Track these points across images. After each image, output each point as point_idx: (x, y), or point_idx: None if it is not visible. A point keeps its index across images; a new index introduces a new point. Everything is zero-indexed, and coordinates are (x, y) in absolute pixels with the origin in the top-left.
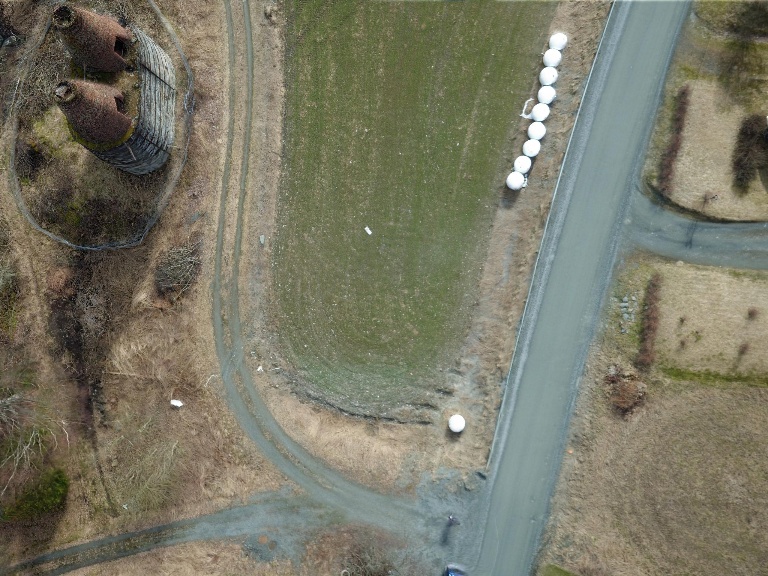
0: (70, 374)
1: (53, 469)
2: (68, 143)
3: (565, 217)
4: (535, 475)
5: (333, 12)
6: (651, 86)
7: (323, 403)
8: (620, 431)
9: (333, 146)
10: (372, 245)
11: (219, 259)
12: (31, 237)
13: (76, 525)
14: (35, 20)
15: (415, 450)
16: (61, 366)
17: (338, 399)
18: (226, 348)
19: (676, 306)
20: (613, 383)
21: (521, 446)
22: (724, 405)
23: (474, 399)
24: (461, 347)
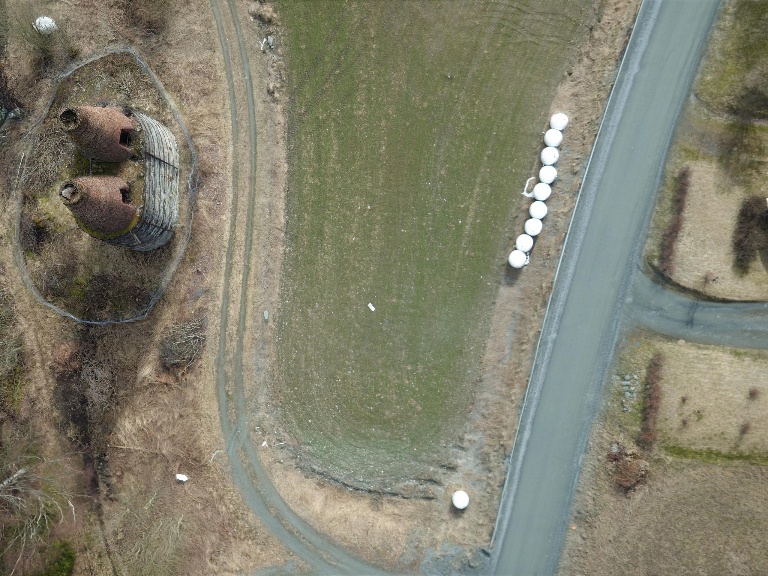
0: (76, 447)
1: (59, 542)
2: (73, 219)
3: (567, 296)
4: (539, 552)
5: (335, 90)
6: (652, 166)
7: (327, 478)
8: (623, 508)
9: (336, 223)
10: (375, 321)
11: (223, 335)
12: (36, 310)
13: None
14: (39, 93)
15: (419, 526)
16: (67, 439)
17: (342, 474)
18: (231, 424)
19: (678, 385)
20: (616, 461)
21: (525, 523)
22: (726, 483)
23: (478, 475)
24: (464, 423)
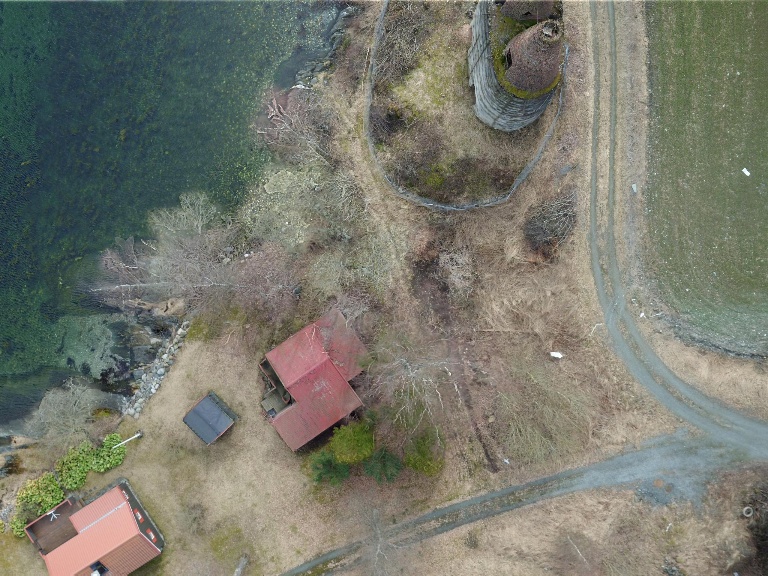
0: (438, 335)
1: None
2: (433, 105)
3: None
4: None
5: None
6: None
7: (708, 345)
8: None
9: (704, 91)
10: (751, 186)
11: (594, 210)
12: (387, 203)
13: (455, 483)
14: None
15: None
16: (428, 327)
17: (724, 340)
18: (608, 297)
19: None
20: None
21: None
22: None
23: None
24: None
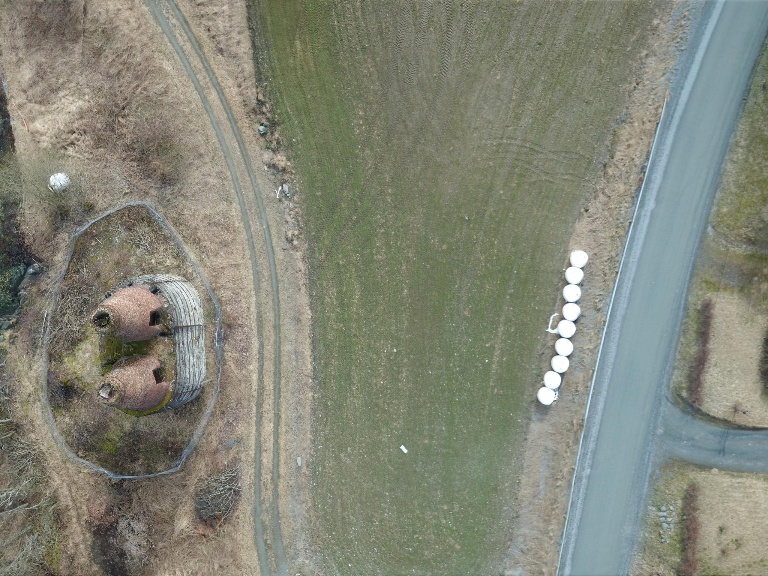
0: None
1: None
2: (100, 378)
3: (598, 432)
4: None
5: (354, 235)
6: (674, 299)
7: None
8: None
9: (363, 367)
10: (409, 463)
11: (258, 484)
12: (68, 466)
13: None
14: (57, 248)
15: None
16: None
17: None
18: (271, 572)
19: (714, 515)
20: None
21: None
22: None
23: None
24: (504, 559)
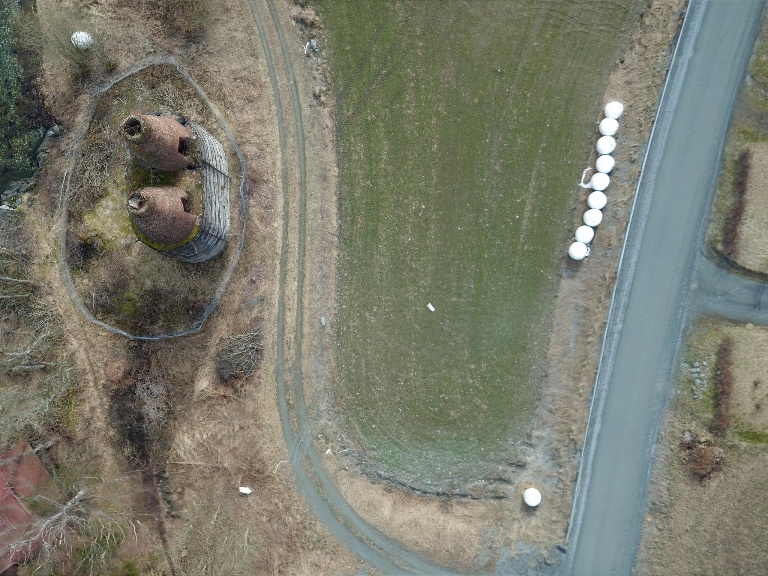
0: (134, 465)
1: (122, 563)
2: (121, 234)
3: (631, 286)
4: (615, 546)
5: (383, 90)
6: (711, 150)
7: (394, 483)
8: (698, 497)
9: (390, 224)
10: (436, 322)
11: (281, 343)
12: (86, 329)
13: None
14: (78, 110)
15: (491, 526)
16: (124, 458)
17: (409, 478)
18: (293, 433)
19: (749, 370)
20: (689, 449)
21: (599, 517)
22: None
23: (548, 471)
24: (531, 420)
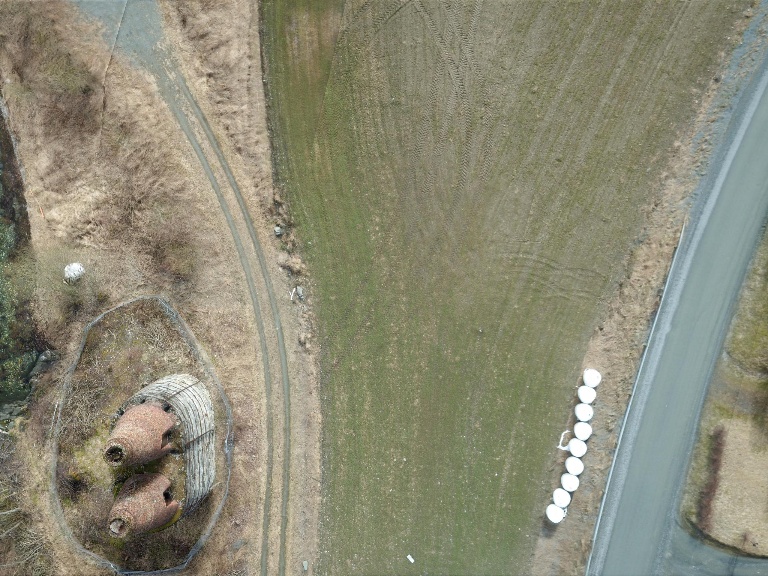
0: None
1: None
2: (109, 474)
3: (606, 553)
4: None
5: (367, 341)
6: (686, 424)
7: None
8: None
9: (372, 474)
10: (415, 573)
11: None
12: (75, 557)
13: None
14: (69, 337)
15: None
16: None
17: None
18: None
19: None
20: None
21: None
22: None
23: None
24: None
